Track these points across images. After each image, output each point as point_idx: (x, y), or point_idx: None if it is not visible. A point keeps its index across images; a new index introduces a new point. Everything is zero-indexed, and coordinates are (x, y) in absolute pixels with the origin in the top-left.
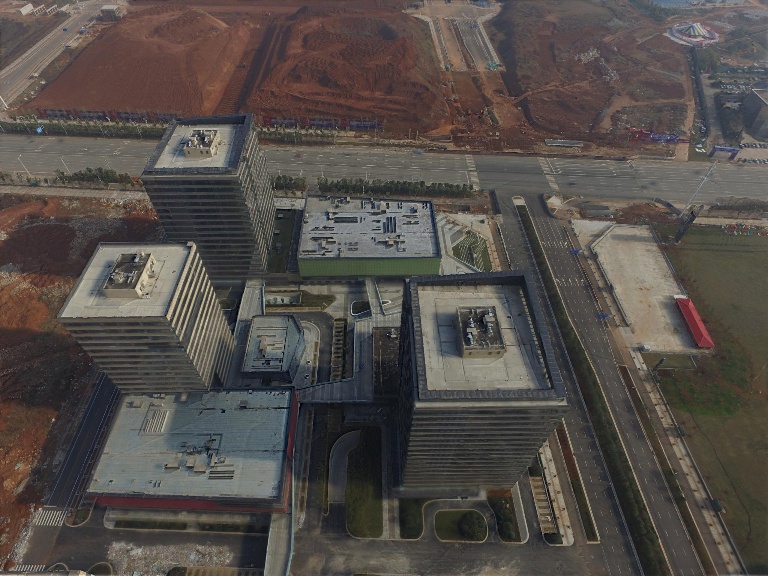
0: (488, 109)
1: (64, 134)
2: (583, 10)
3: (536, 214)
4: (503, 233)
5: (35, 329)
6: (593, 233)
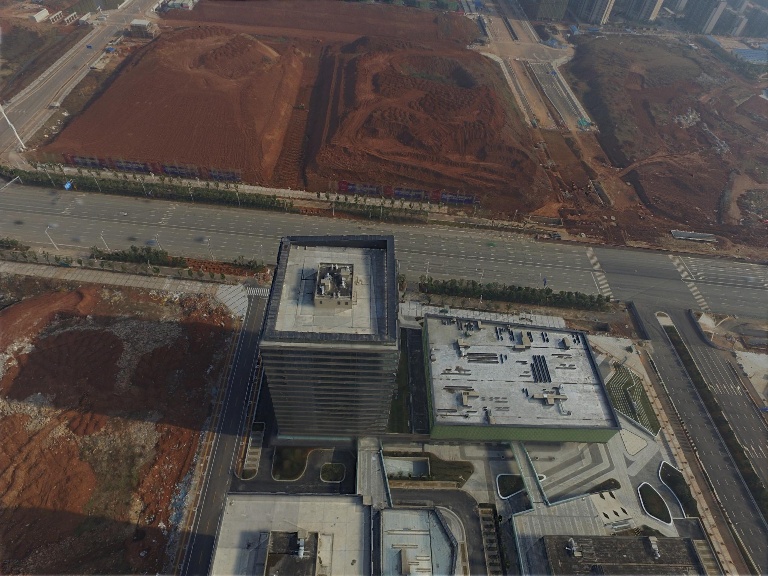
0: (594, 183)
1: (97, 190)
2: (668, 61)
3: (690, 341)
4: (659, 369)
5: (79, 513)
6: (766, 373)
